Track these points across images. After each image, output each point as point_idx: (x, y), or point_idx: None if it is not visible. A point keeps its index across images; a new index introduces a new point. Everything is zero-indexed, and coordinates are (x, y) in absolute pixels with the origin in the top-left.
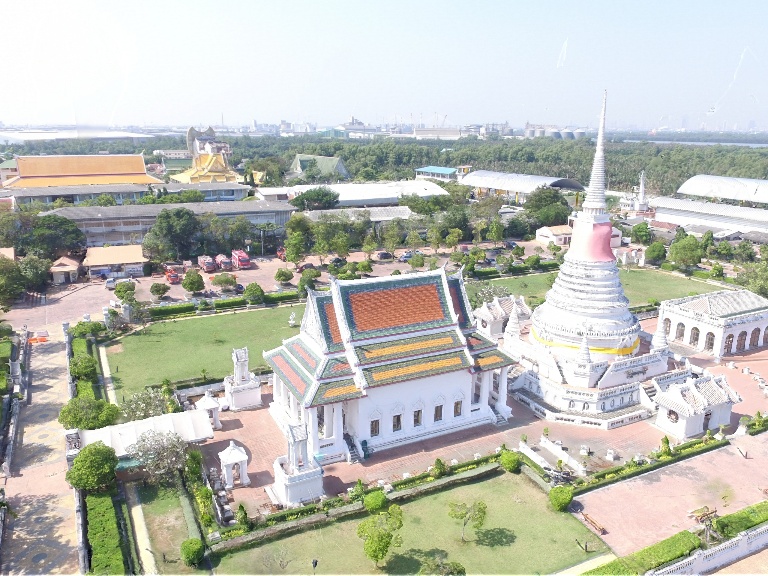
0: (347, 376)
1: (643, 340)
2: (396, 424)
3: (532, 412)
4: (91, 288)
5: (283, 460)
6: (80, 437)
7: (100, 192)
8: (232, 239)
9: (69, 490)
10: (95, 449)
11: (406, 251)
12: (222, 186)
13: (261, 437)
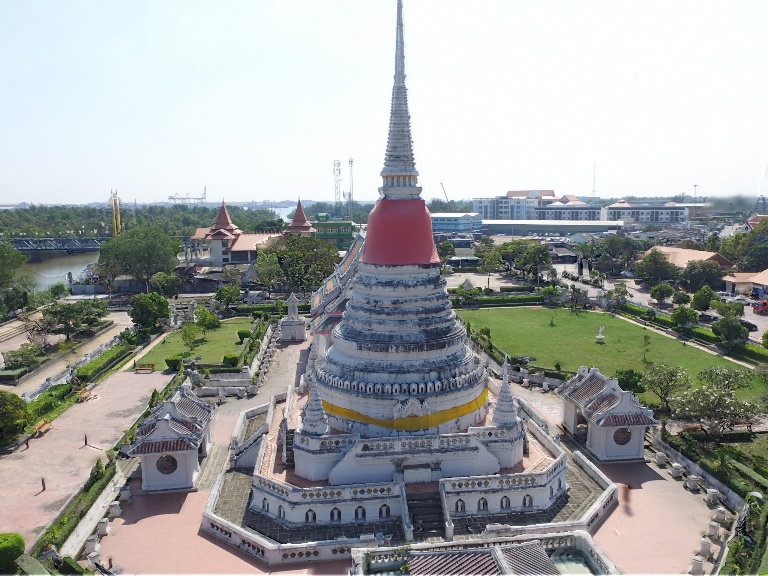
0: None
1: None
2: None
3: None
4: None
5: None
6: None
7: None
8: None
9: None
10: None
11: None
12: None
13: None
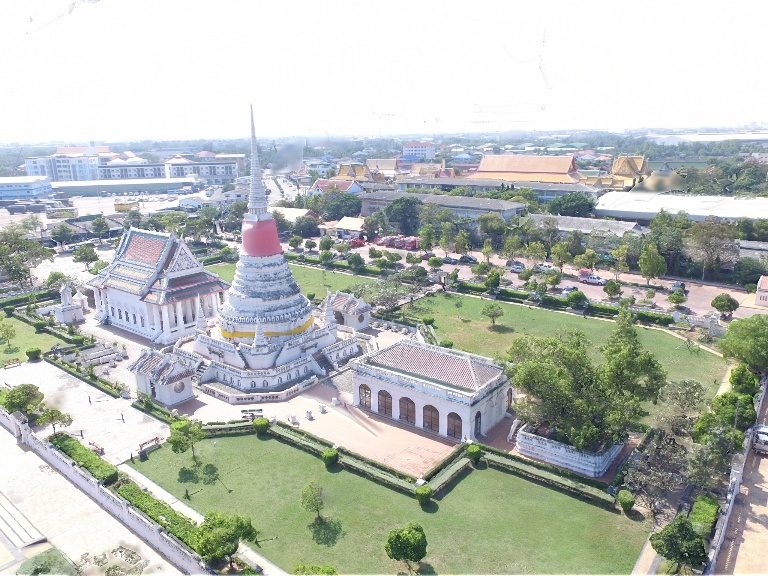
0: None
1: None
2: None
3: None
4: None
5: None
6: None
7: (468, 184)
8: None
9: None
10: (55, 273)
11: None
12: (568, 187)
13: None
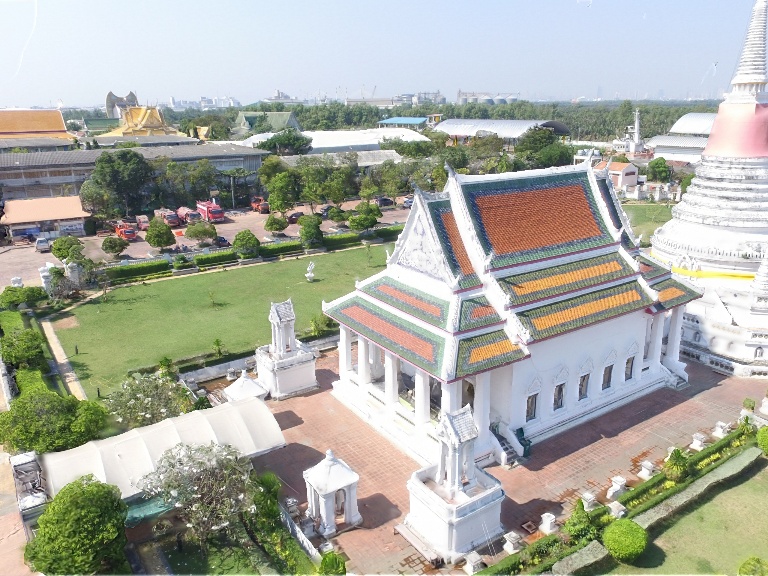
0: (494, 326)
1: None
2: (556, 398)
3: (707, 367)
4: (15, 252)
5: (424, 476)
6: (41, 468)
7: (12, 146)
8: (194, 189)
9: (30, 575)
10: (82, 494)
11: (408, 196)
12: (164, 139)
13: (340, 436)
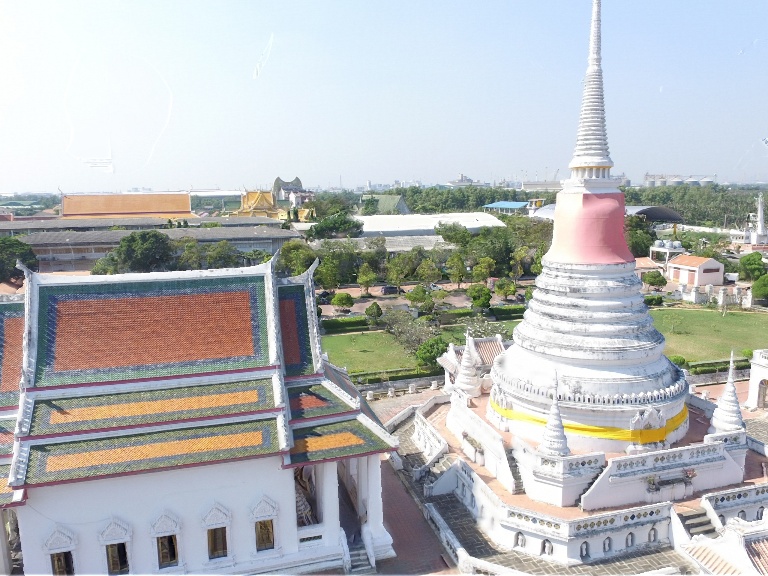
0: None
1: (700, 415)
2: (117, 561)
3: (440, 548)
4: None
5: None
6: None
7: None
8: None
9: None
10: None
11: (419, 285)
12: (251, 220)
13: None
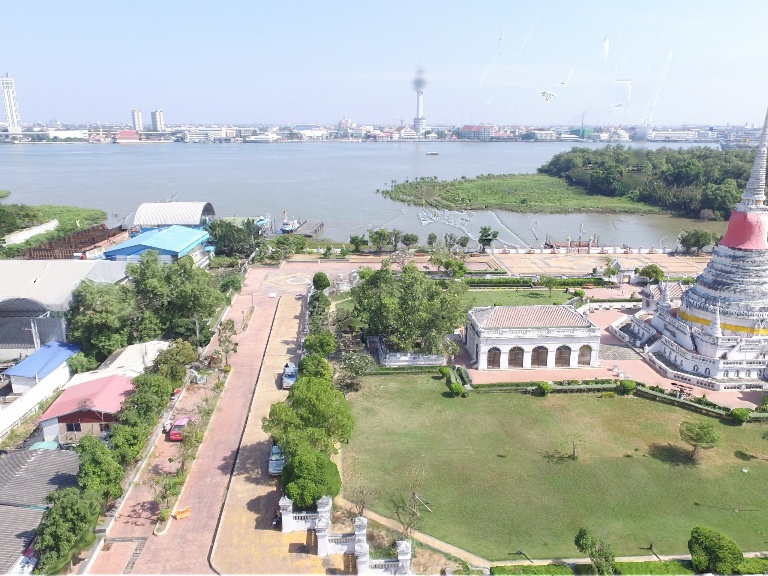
0: None
1: None
2: None
3: None
4: None
5: None
6: None
7: None
8: None
9: None
10: None
11: None
12: None
13: None
